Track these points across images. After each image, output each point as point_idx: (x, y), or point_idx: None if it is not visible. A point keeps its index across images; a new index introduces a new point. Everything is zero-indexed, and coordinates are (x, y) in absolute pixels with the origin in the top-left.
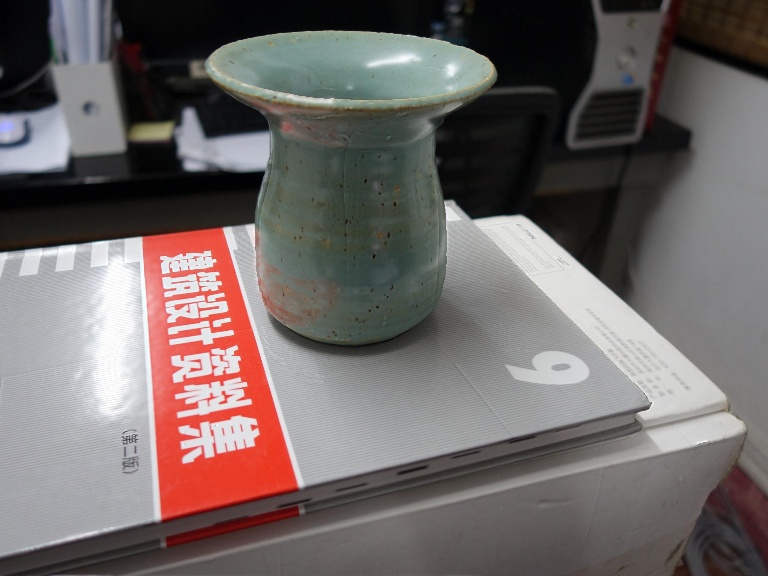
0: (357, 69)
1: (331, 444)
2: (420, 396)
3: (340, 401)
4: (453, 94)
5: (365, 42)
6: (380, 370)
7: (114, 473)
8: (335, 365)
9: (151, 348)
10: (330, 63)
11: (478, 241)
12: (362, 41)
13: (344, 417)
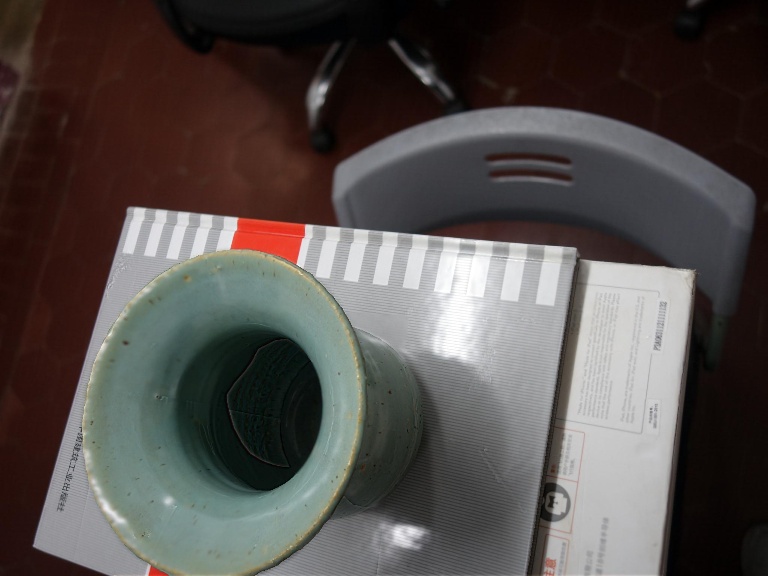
0: (282, 319)
1: None
2: None
3: None
4: None
5: (291, 289)
6: None
7: None
8: None
9: None
10: (254, 304)
11: (538, 366)
12: (288, 286)
13: None
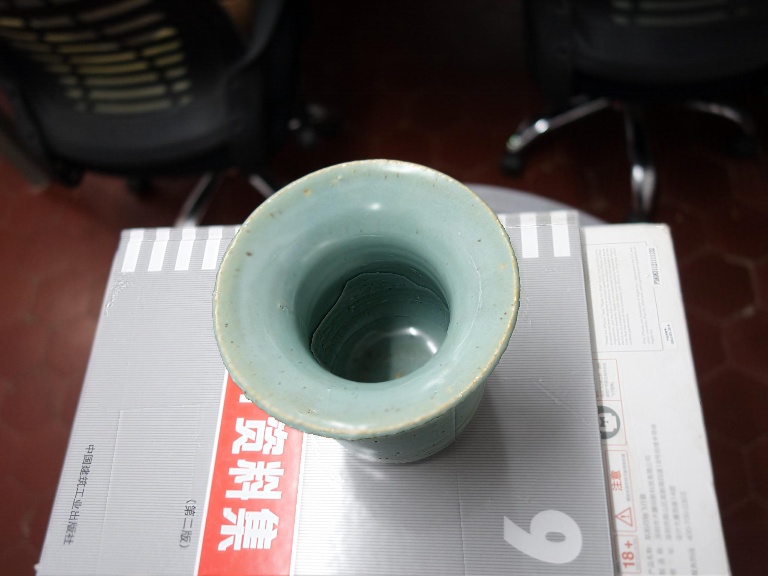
0: (401, 220)
1: (323, 567)
2: (412, 534)
3: (346, 518)
4: (415, 423)
5: (416, 185)
6: (392, 488)
7: (174, 544)
8: (358, 469)
9: (225, 402)
10: (372, 210)
11: (570, 304)
12: (413, 183)
13: (343, 539)
